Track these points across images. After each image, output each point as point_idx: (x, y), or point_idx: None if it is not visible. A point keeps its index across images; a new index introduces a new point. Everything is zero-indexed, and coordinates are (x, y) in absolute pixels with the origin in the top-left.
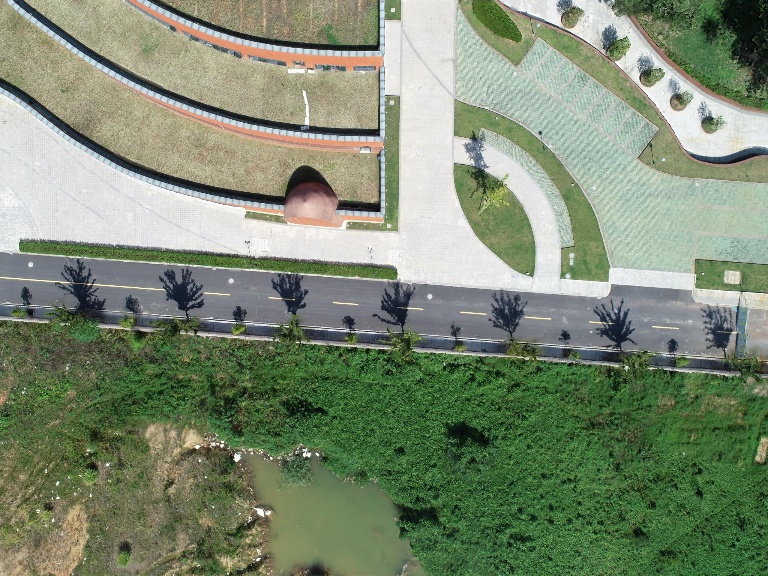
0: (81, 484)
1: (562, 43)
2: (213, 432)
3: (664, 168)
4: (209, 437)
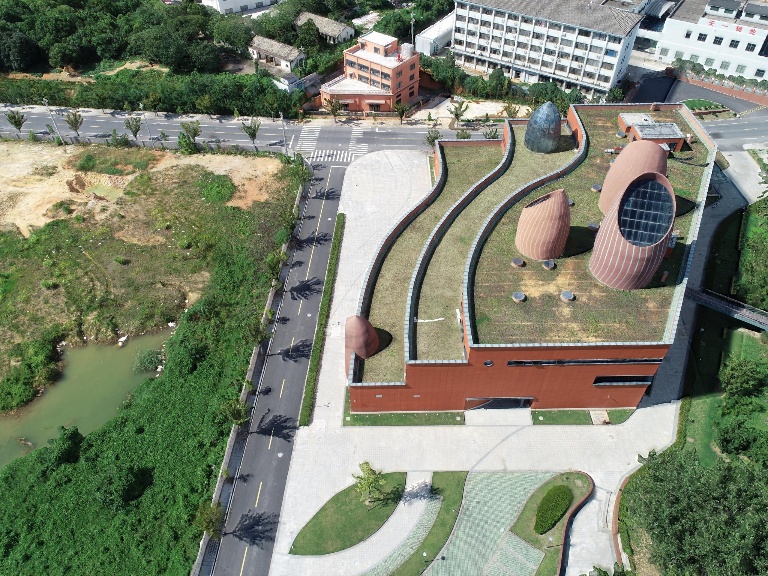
0: None
1: None
2: None
3: None
4: None
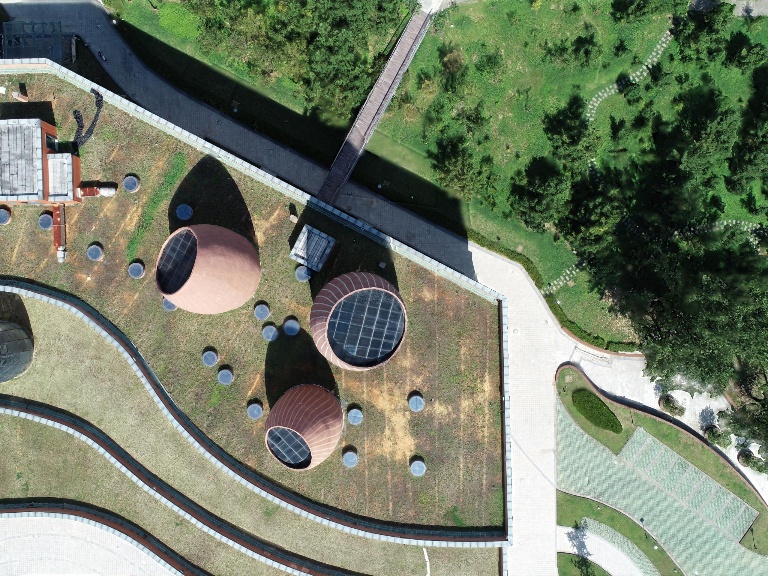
0: None
1: (662, 432)
2: None
3: (765, 552)
4: None
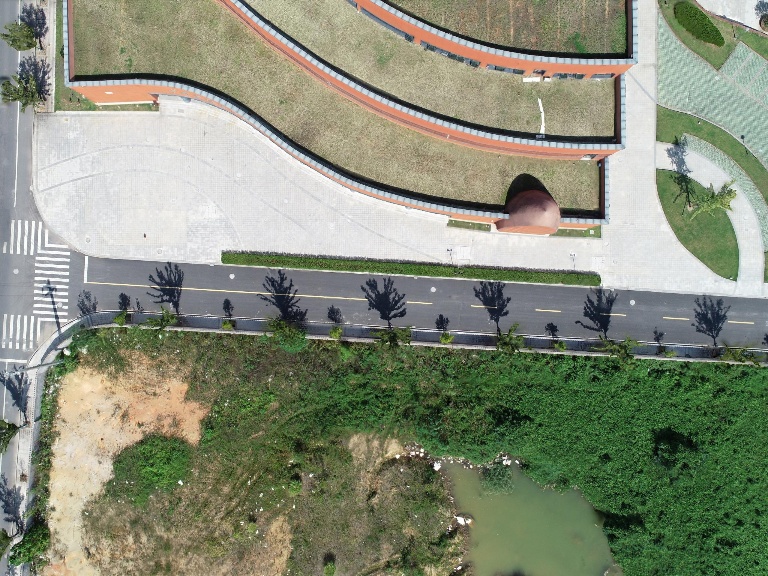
0: (284, 495)
1: (764, 47)
2: (413, 441)
3: None
4: (409, 446)
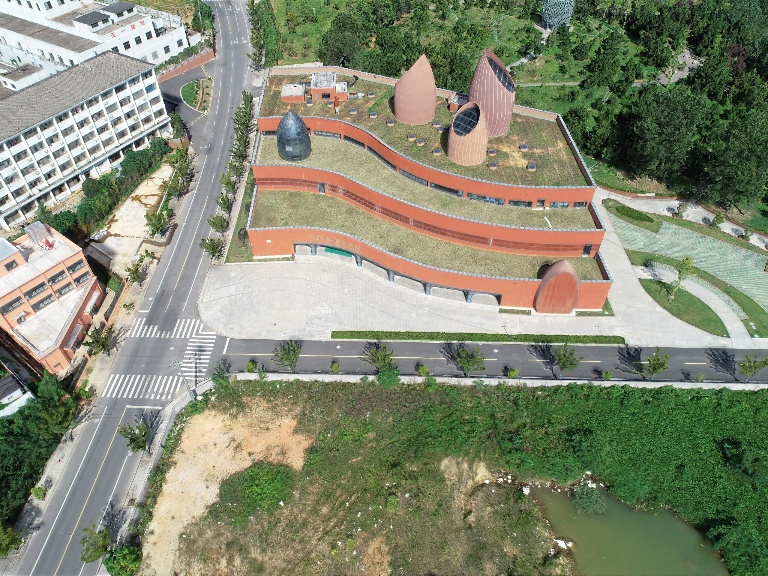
0: (382, 515)
1: (680, 223)
2: (499, 468)
3: None
4: (496, 473)
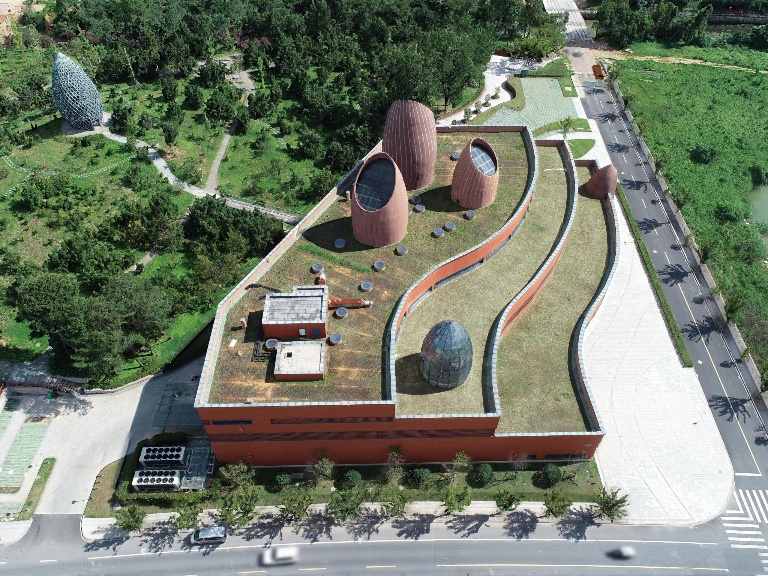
0: None
1: None
2: None
3: None
4: (767, 268)
